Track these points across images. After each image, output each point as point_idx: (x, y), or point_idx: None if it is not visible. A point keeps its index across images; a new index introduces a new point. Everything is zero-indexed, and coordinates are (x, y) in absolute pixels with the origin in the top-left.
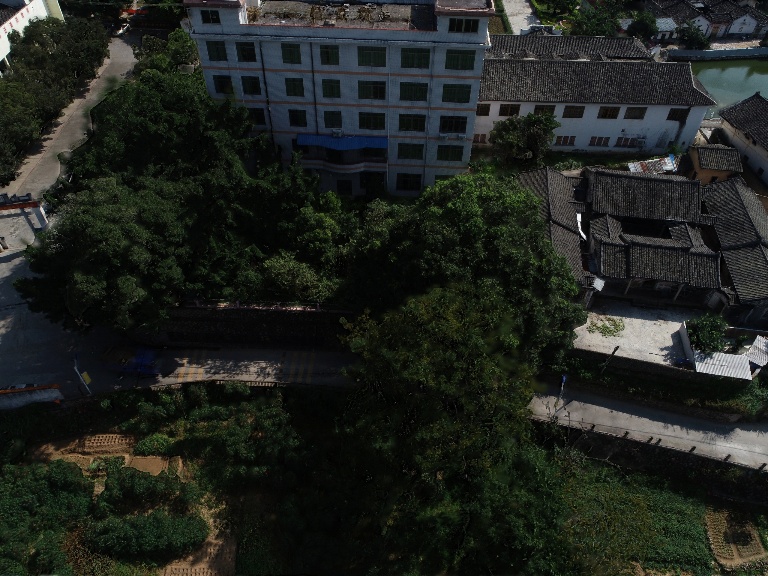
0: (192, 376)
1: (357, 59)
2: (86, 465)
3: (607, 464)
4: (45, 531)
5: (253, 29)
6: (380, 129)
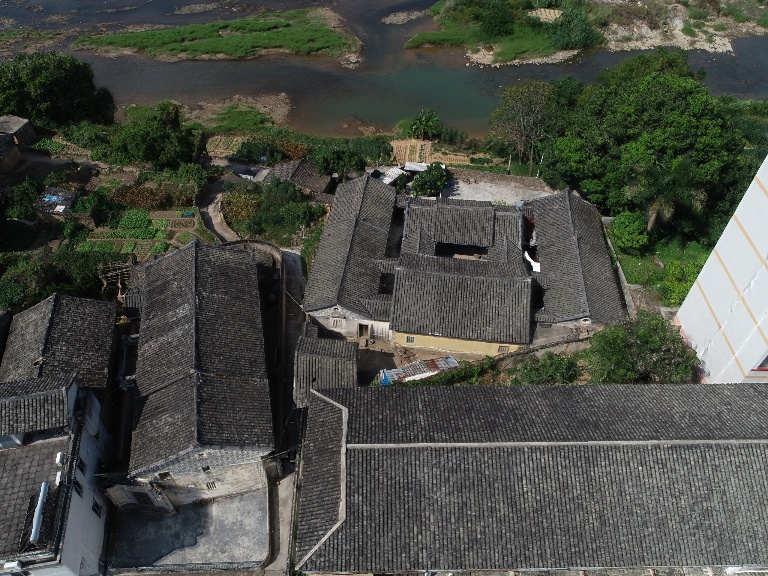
0: None
1: None
2: None
3: None
4: None
5: None
6: None
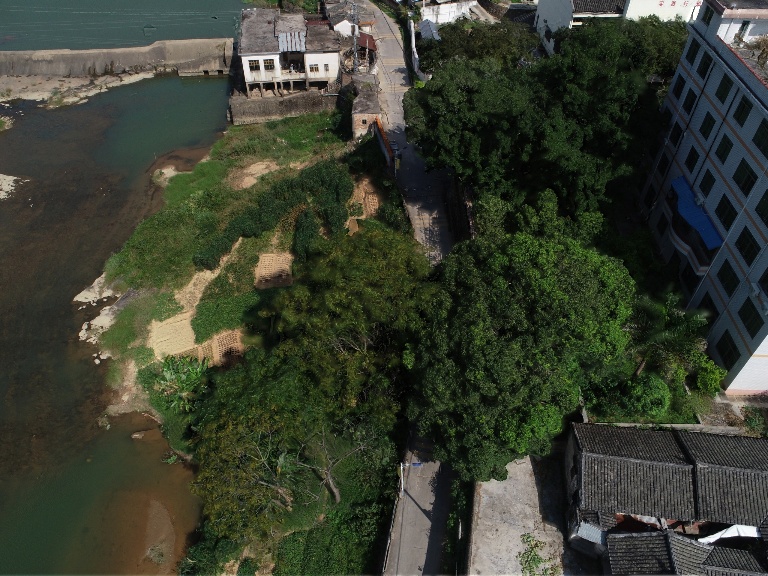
0: (421, 222)
1: (756, 132)
2: (356, 201)
3: (365, 571)
4: (315, 198)
5: (720, 45)
6: (726, 228)
